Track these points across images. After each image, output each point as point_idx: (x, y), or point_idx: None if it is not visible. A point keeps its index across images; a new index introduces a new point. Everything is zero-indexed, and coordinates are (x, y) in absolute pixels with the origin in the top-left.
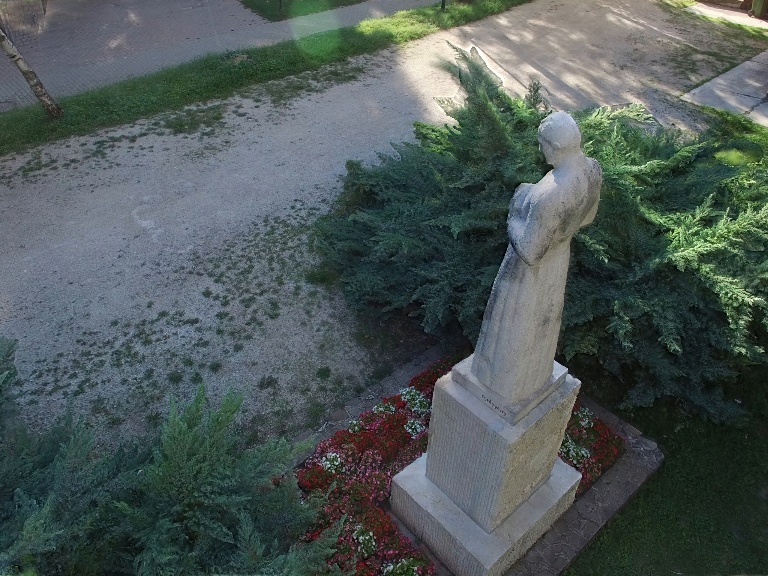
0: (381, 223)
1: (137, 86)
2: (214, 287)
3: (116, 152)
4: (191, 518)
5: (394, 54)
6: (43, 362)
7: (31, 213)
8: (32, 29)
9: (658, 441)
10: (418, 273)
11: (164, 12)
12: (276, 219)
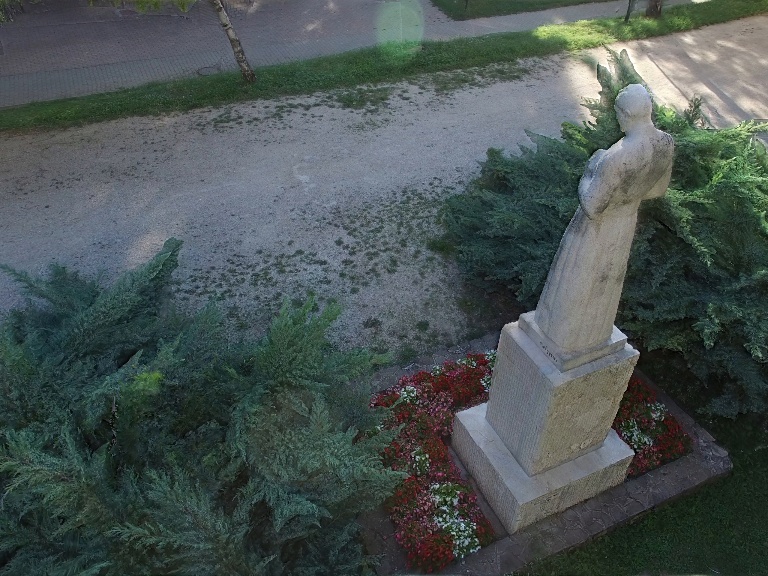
0: (503, 204)
1: (321, 64)
2: (346, 239)
3: (291, 117)
4: (280, 392)
5: (564, 60)
6: (199, 271)
7: (214, 156)
8: (244, 4)
9: (733, 454)
10: (523, 248)
11: (360, 4)
12: (413, 191)
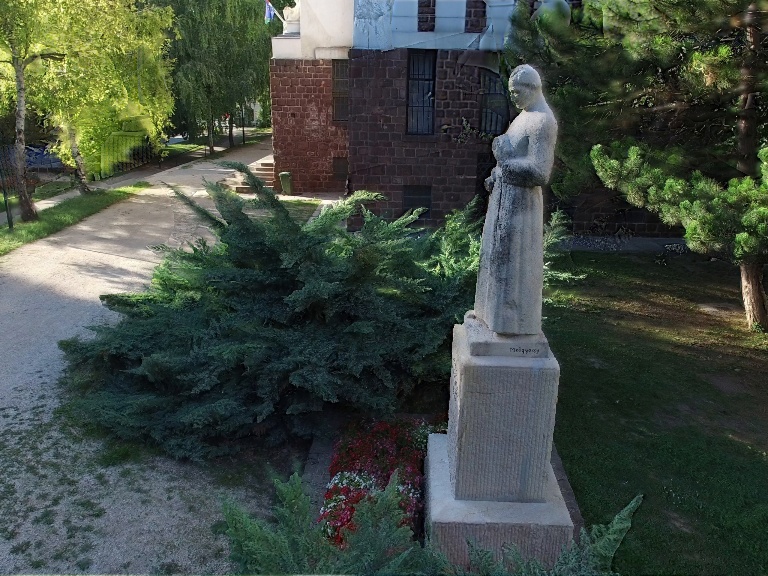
0: (182, 357)
1: None
2: None
3: None
4: None
5: None
6: None
7: None
8: None
9: None
10: (287, 360)
11: None
12: None
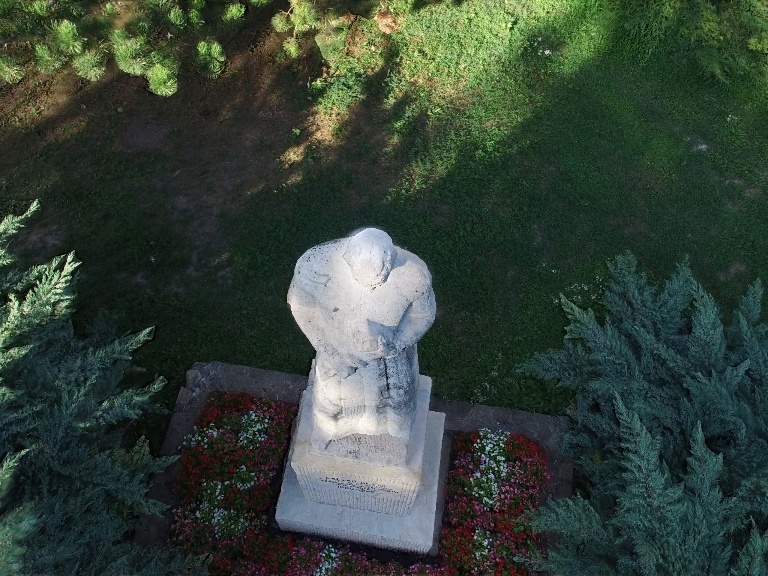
0: None
1: None
2: None
3: None
4: None
5: None
6: None
7: None
8: None
9: (170, 379)
10: None
11: None
12: None
